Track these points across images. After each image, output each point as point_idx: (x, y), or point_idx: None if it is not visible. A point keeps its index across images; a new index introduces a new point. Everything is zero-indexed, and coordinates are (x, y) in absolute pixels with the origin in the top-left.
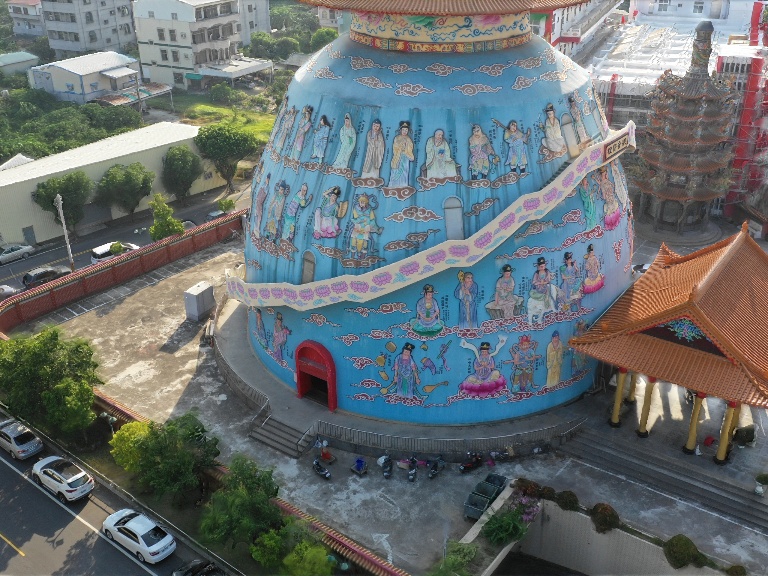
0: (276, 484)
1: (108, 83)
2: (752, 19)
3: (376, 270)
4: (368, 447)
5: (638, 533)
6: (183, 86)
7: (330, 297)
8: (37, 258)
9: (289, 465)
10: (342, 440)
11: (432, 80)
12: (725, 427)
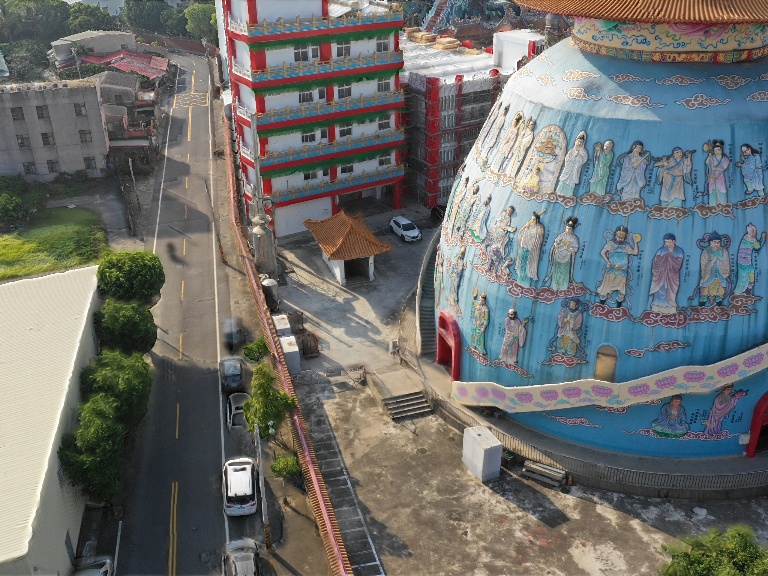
0: None
1: None
2: None
3: None
4: None
5: None
6: None
7: None
8: (128, 572)
9: None
10: None
11: None
12: None
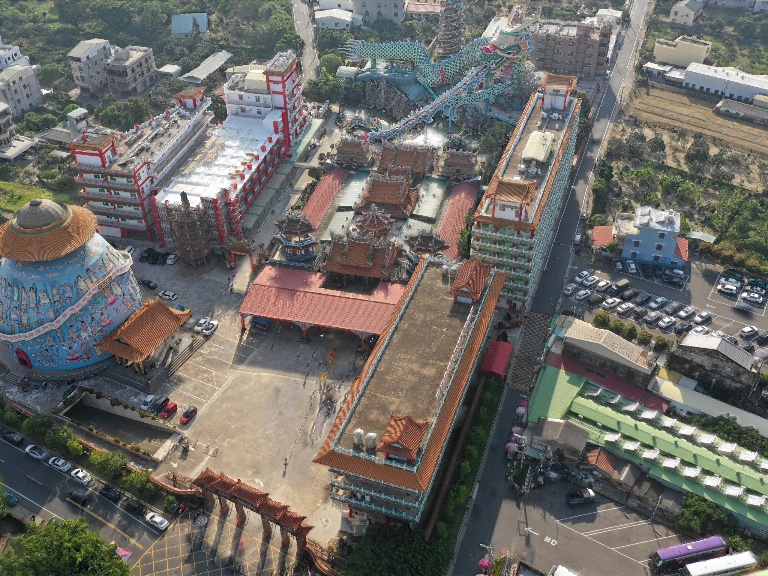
0: None
1: None
2: (274, 128)
3: (29, 332)
4: (40, 380)
5: (108, 398)
6: None
7: (18, 339)
8: None
9: (15, 388)
10: (32, 379)
11: (39, 273)
12: (141, 365)
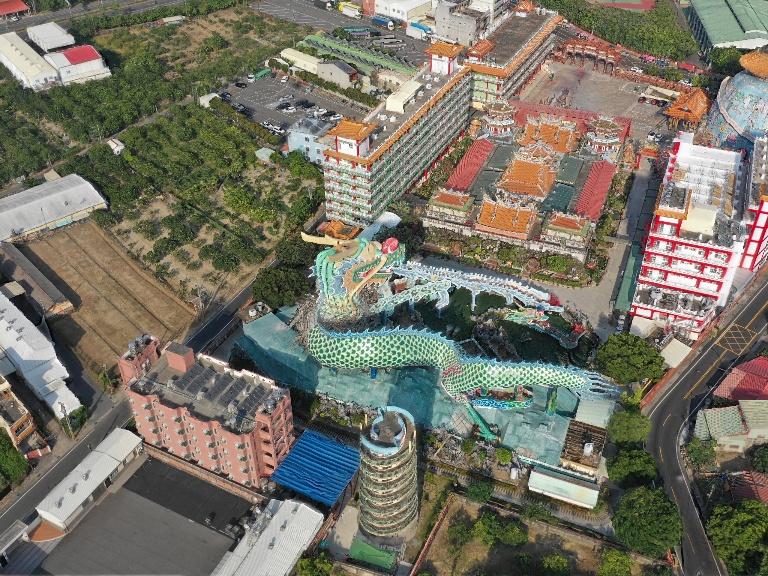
0: None
1: None
2: None
3: None
4: None
5: None
6: None
7: None
8: None
9: None
10: None
11: None
12: None
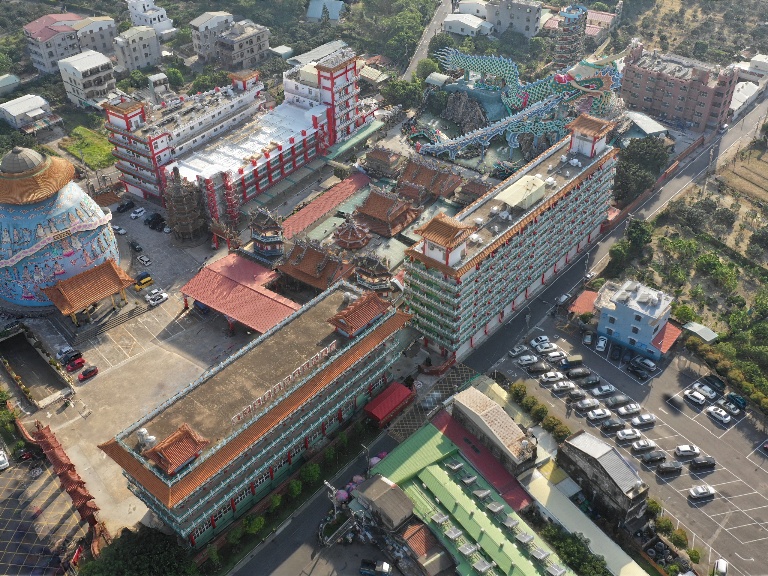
0: None
1: (31, 117)
2: (313, 122)
3: None
4: None
5: None
6: (83, 107)
7: None
8: None
9: None
10: None
11: (7, 214)
12: (74, 317)
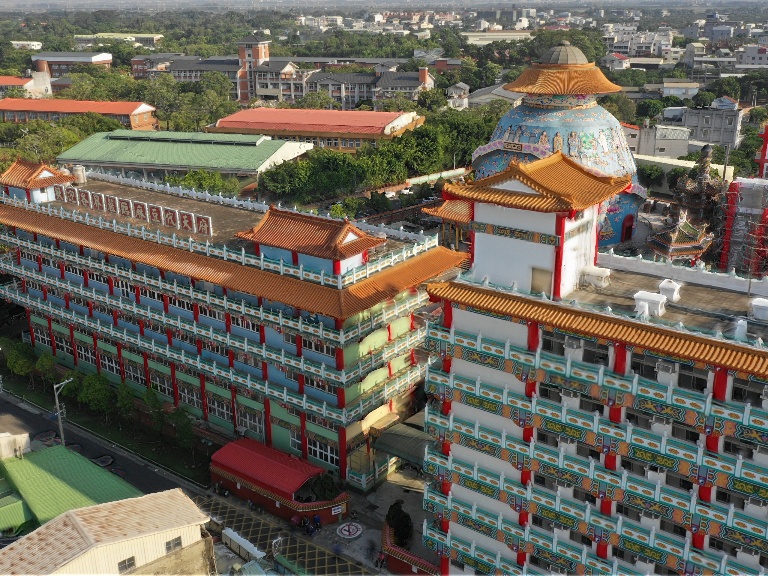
0: (424, 190)
1: None
2: None
3: None
4: None
5: None
6: None
7: None
8: None
9: None
10: None
11: None
12: None
